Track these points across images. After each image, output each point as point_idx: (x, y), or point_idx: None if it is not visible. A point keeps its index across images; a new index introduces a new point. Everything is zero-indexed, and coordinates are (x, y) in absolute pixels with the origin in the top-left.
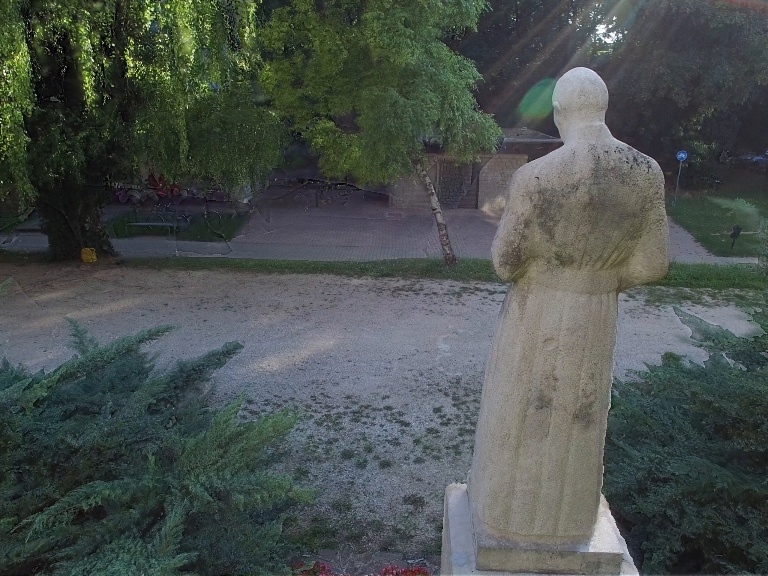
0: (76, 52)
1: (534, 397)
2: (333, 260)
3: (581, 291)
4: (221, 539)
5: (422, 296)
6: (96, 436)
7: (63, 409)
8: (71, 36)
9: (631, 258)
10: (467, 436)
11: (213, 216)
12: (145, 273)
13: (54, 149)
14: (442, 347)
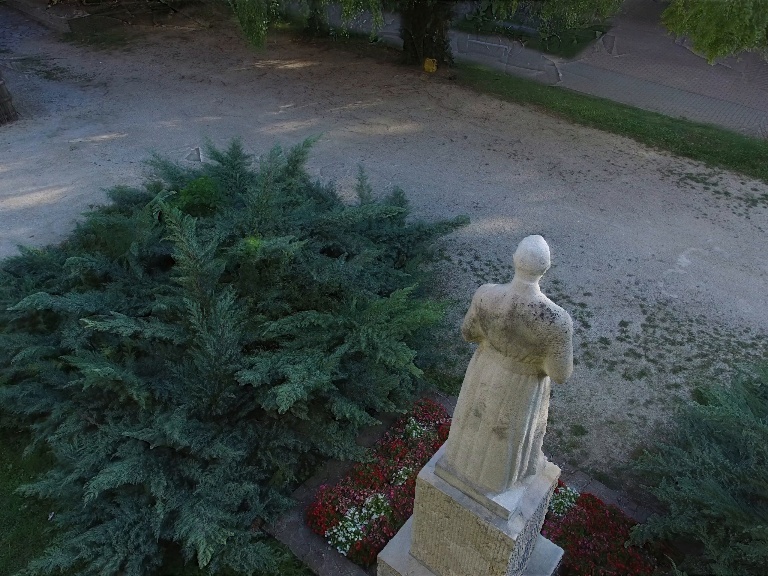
0: None
1: (473, 408)
2: (666, 108)
3: (506, 368)
4: (366, 371)
5: (709, 193)
6: (327, 276)
7: (324, 245)
8: None
9: (543, 363)
10: (631, 358)
11: (554, 39)
12: (467, 95)
13: None
14: (681, 261)
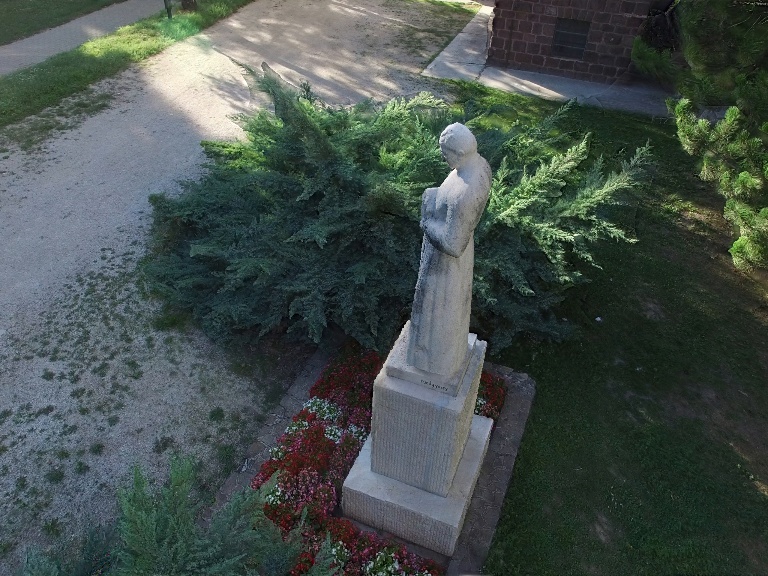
0: None
1: None
2: None
3: None
4: None
5: None
6: None
7: None
8: None
9: None
10: (108, 372)
11: None
12: None
13: None
14: None
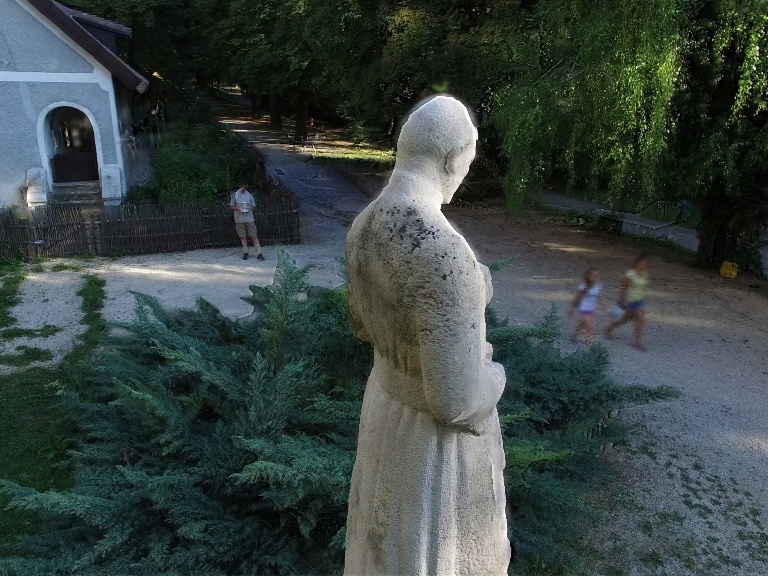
0: (738, 60)
1: None
2: None
3: (383, 385)
4: None
5: None
6: None
7: None
8: (739, 44)
9: None
10: None
11: None
12: (767, 304)
13: (708, 157)
14: None
